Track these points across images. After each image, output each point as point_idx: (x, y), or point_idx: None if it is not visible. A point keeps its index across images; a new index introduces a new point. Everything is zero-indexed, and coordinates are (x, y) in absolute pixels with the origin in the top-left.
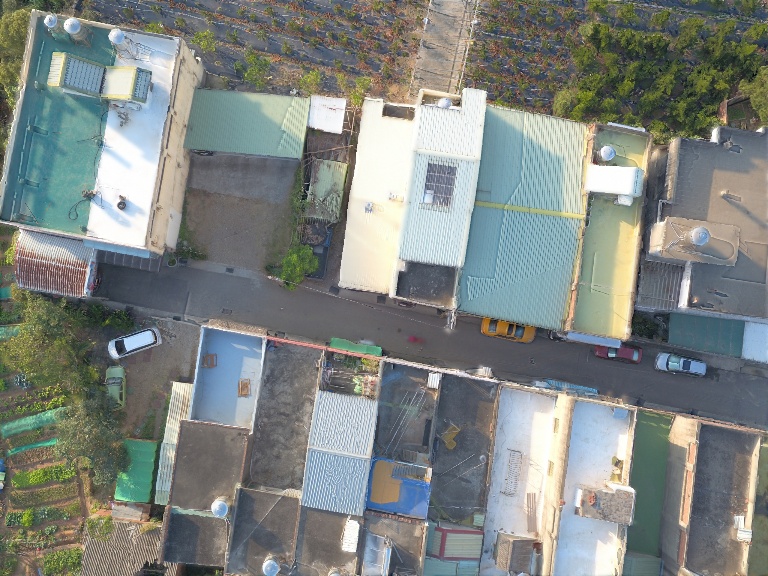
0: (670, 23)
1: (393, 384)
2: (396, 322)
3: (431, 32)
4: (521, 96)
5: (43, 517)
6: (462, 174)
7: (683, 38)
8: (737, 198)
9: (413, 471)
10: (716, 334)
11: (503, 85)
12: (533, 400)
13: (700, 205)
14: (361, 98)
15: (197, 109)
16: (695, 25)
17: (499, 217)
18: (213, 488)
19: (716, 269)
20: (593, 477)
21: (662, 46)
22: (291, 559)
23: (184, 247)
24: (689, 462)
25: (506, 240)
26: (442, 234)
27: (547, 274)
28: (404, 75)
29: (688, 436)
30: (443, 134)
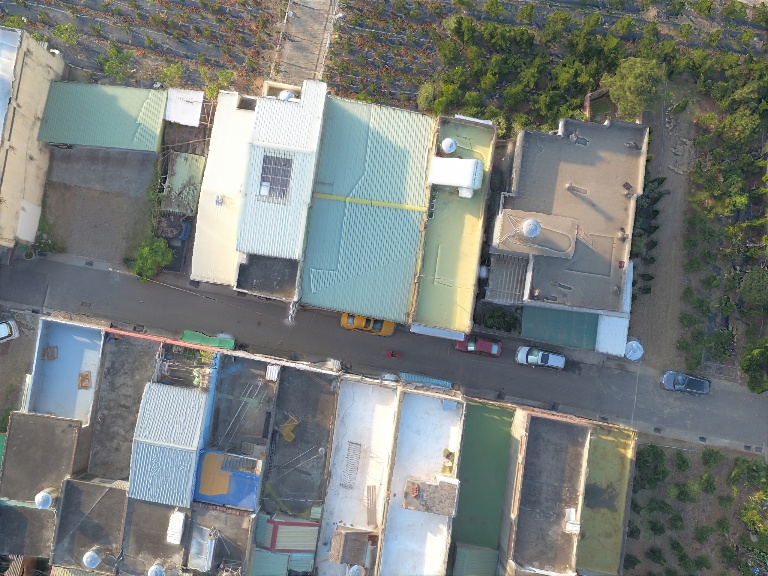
0: (537, 16)
1: (234, 376)
2: (256, 315)
3: (296, 25)
4: (386, 89)
5: None
6: (298, 166)
7: (547, 31)
8: (583, 191)
9: (248, 463)
10: (570, 327)
11: (368, 78)
12: (375, 393)
13: (545, 198)
14: (216, 91)
15: (53, 102)
16: (559, 18)
17: (341, 209)
18: (43, 480)
19: (560, 262)
20: (424, 469)
21: (525, 39)
22: (117, 551)
23: (43, 240)
24: (520, 454)
25: (348, 232)
26: (279, 226)
27: (390, 267)
28: (269, 68)
29: (521, 428)
30: (280, 126)
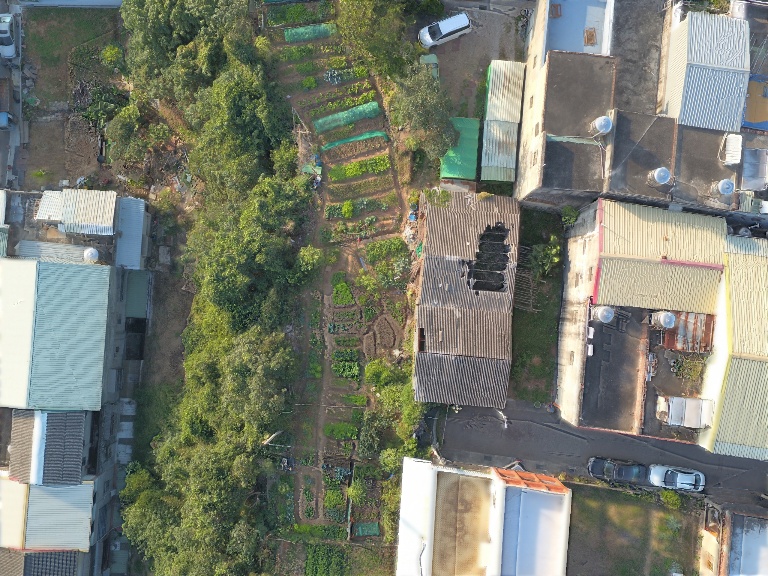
0: None
1: None
2: None
3: None
4: None
5: (362, 207)
6: None
7: None
8: None
9: None
10: None
11: None
12: None
13: None
14: None
15: None
16: None
17: None
18: (585, 116)
19: None
20: None
21: None
22: None
23: None
24: None
25: None
26: None
27: None
28: None
29: None
30: None
